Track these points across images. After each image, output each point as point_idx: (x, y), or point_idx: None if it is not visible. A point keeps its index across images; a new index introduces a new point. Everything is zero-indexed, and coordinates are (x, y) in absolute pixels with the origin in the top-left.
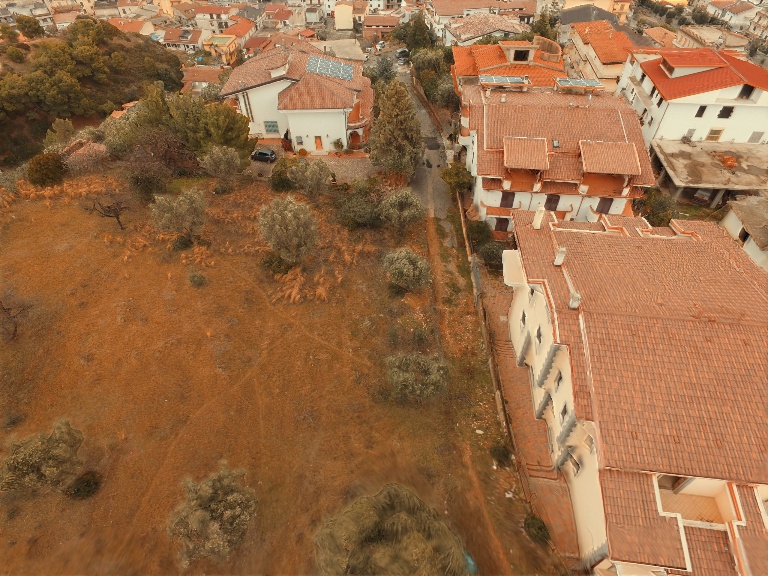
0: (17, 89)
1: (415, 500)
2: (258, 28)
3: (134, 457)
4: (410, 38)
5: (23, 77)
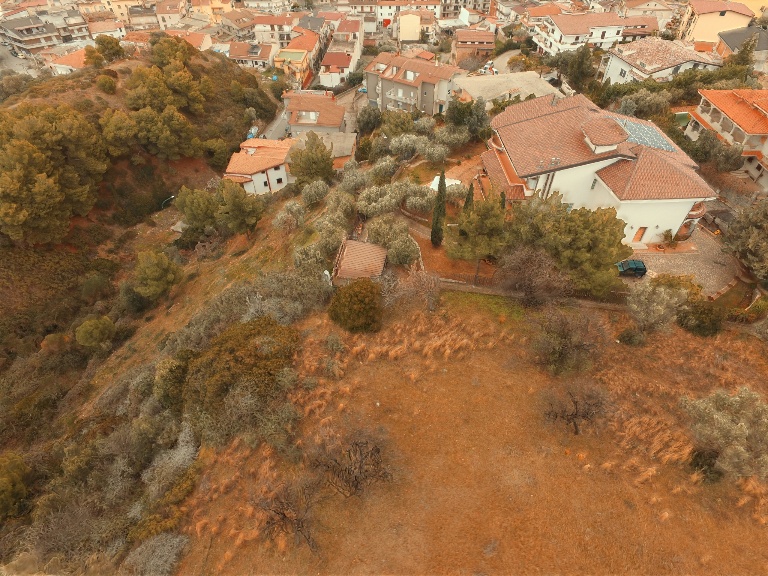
0: (125, 130)
1: None
2: (321, 40)
3: None
4: (575, 67)
5: (129, 115)
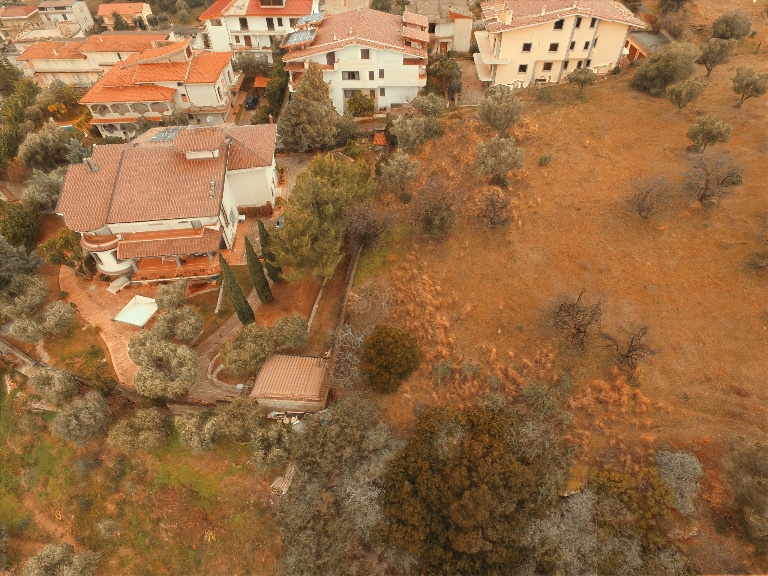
0: None
1: (645, 61)
2: None
3: (670, 145)
4: None
5: None
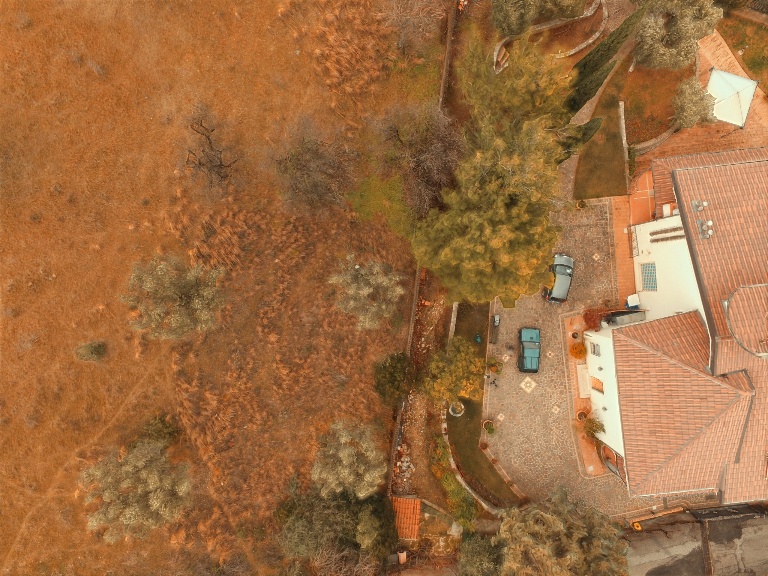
0: None
1: None
2: None
3: None
4: None
5: None
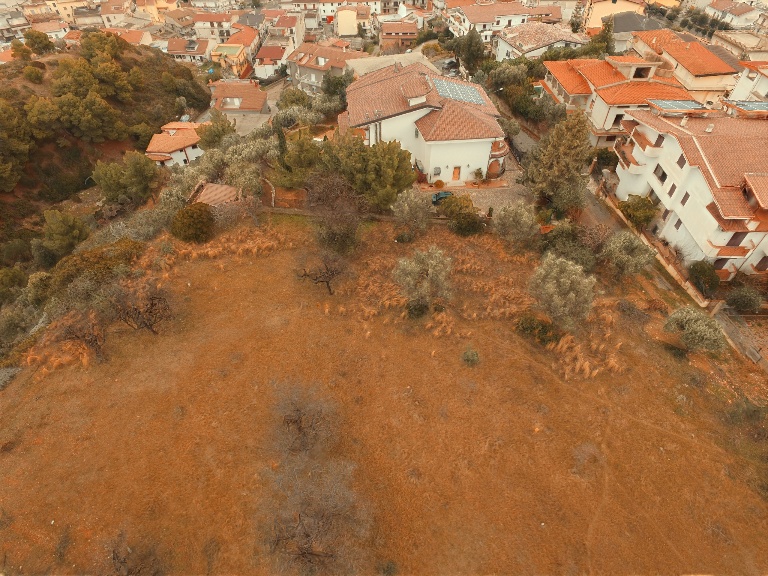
0: (47, 114)
1: None
2: (260, 36)
3: None
4: (465, 49)
5: (52, 101)
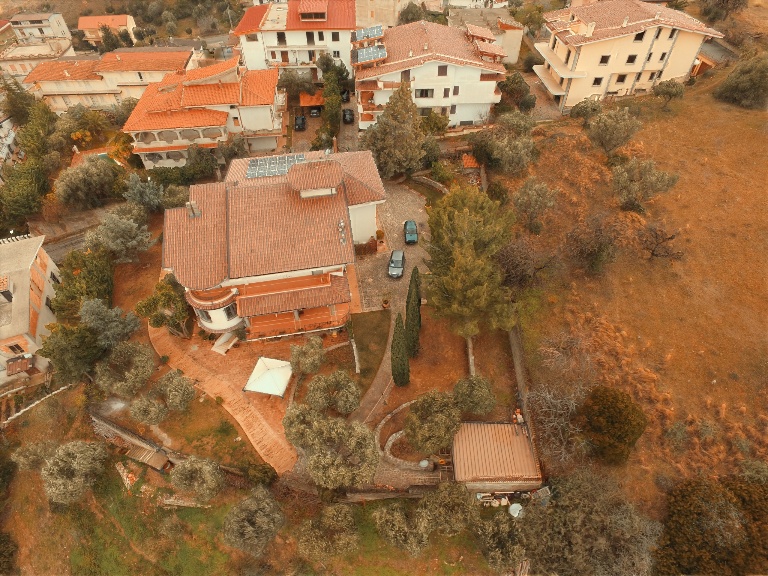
0: None
1: None
2: None
3: None
4: None
5: None
